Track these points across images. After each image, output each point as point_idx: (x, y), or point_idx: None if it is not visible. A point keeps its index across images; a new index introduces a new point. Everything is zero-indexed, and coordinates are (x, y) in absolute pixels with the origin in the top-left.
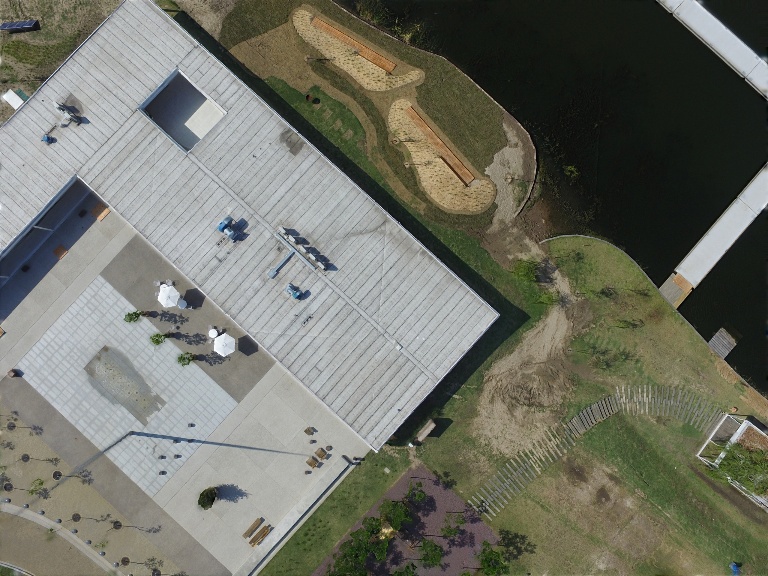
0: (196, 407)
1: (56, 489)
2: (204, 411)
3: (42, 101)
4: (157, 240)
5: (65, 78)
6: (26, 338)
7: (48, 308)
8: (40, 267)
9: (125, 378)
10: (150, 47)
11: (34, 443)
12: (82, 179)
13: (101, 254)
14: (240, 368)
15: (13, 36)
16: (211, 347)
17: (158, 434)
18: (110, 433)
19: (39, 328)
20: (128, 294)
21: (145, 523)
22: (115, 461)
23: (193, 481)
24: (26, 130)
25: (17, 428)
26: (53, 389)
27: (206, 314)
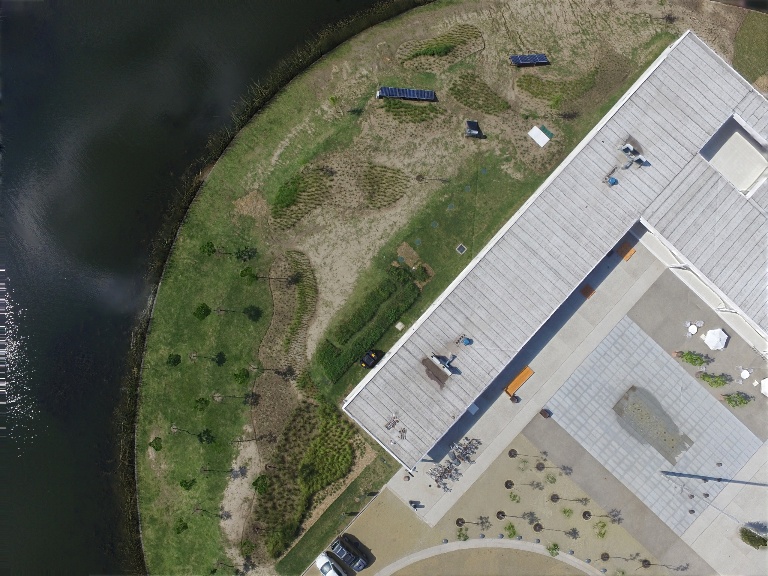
0: (722, 446)
1: (586, 529)
2: (731, 450)
3: (602, 142)
4: (723, 284)
5: (624, 119)
6: (554, 378)
7: (576, 348)
8: (567, 307)
9: (653, 418)
10: (706, 90)
11: (564, 483)
12: (647, 222)
13: (628, 294)
14: (765, 408)
15: (522, 70)
16: (737, 387)
17: (686, 473)
18: (639, 473)
19: (567, 368)
20: (655, 334)
21: (673, 561)
22: (644, 500)
23: (720, 519)
24: (587, 171)
25: (547, 468)
26: (582, 429)
27: (731, 355)
